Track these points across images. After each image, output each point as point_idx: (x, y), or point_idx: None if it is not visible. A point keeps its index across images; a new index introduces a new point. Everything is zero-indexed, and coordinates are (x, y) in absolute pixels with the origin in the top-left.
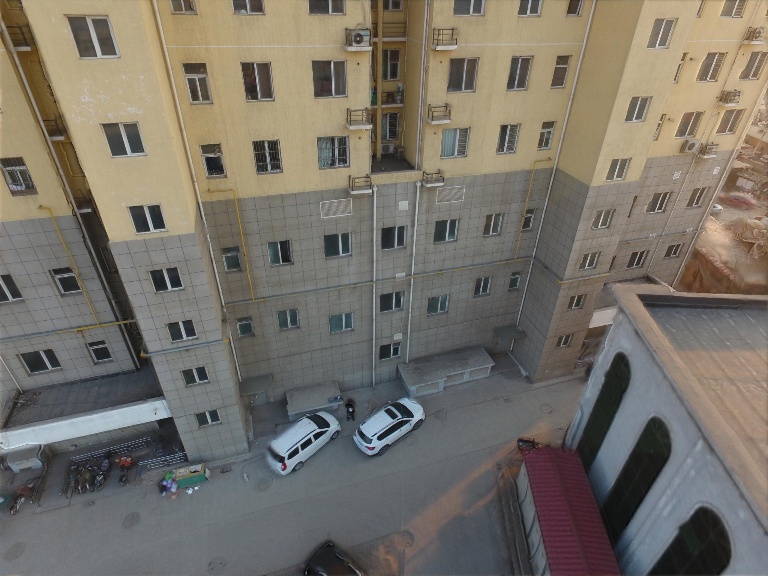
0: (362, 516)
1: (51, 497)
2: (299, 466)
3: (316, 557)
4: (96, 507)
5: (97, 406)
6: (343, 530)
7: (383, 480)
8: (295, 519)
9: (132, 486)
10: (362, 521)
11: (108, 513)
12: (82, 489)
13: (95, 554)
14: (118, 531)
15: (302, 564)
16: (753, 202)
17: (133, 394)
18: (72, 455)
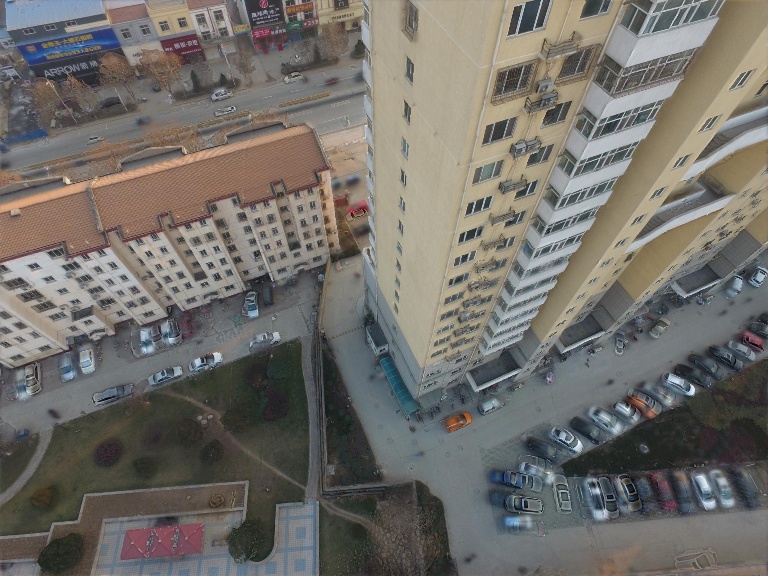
0: (764, 305)
1: (671, 310)
2: (739, 293)
3: (761, 317)
4: (686, 311)
5: (700, 283)
6: (765, 309)
7: (763, 294)
8: (746, 308)
9: (690, 304)
10: (766, 306)
11: (691, 312)
12: (680, 307)
13: (699, 323)
14: (699, 316)
15: (756, 319)
16: None
17: (706, 278)
18: (669, 297)
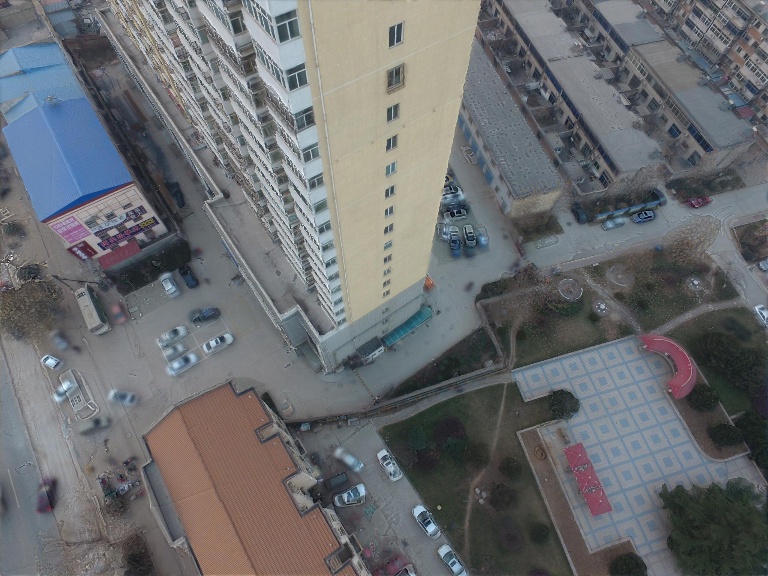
0: None
1: None
2: None
3: None
4: None
5: None
6: None
7: None
8: None
9: None
10: None
11: None
12: None
13: None
14: None
15: None
16: (94, 5)
17: None
18: None
